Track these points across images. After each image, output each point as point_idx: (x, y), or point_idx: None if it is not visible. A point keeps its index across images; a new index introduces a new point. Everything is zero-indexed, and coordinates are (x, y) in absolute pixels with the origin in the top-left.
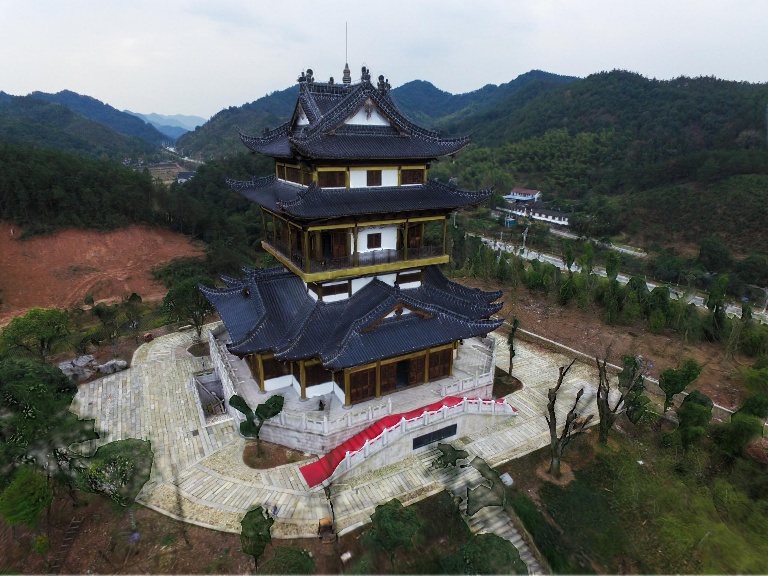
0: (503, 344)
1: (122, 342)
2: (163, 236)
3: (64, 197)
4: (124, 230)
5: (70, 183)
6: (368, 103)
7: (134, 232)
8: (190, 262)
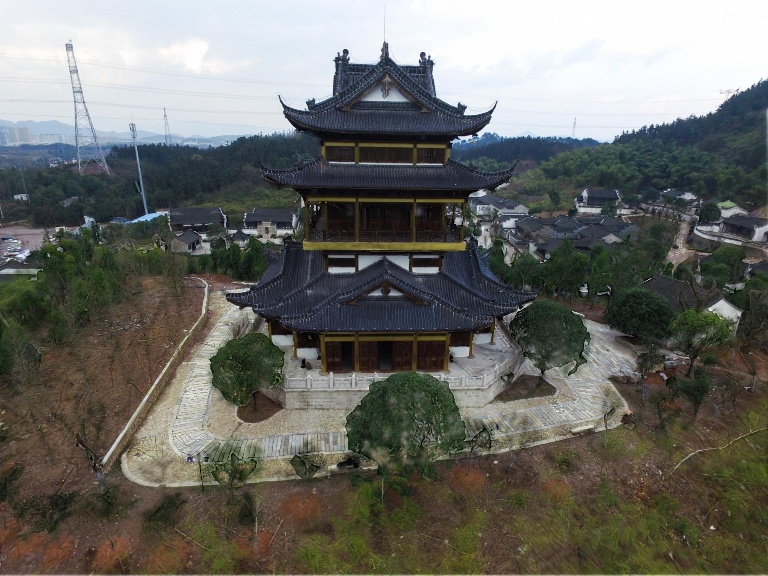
0: (232, 322)
1: (667, 427)
2: None
3: None
4: None
5: None
6: None
7: None
8: None
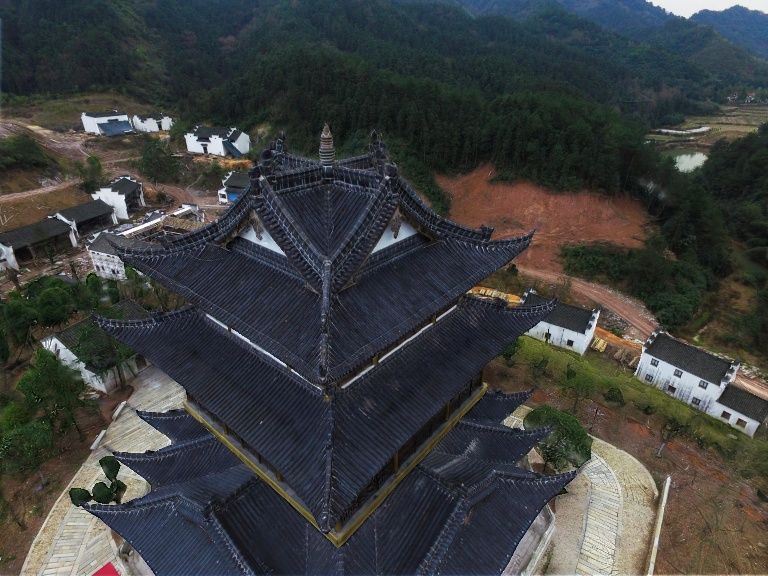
0: None
1: None
2: (622, 209)
3: (534, 151)
4: (572, 194)
5: (550, 137)
6: (255, 217)
7: (582, 199)
8: (608, 251)
